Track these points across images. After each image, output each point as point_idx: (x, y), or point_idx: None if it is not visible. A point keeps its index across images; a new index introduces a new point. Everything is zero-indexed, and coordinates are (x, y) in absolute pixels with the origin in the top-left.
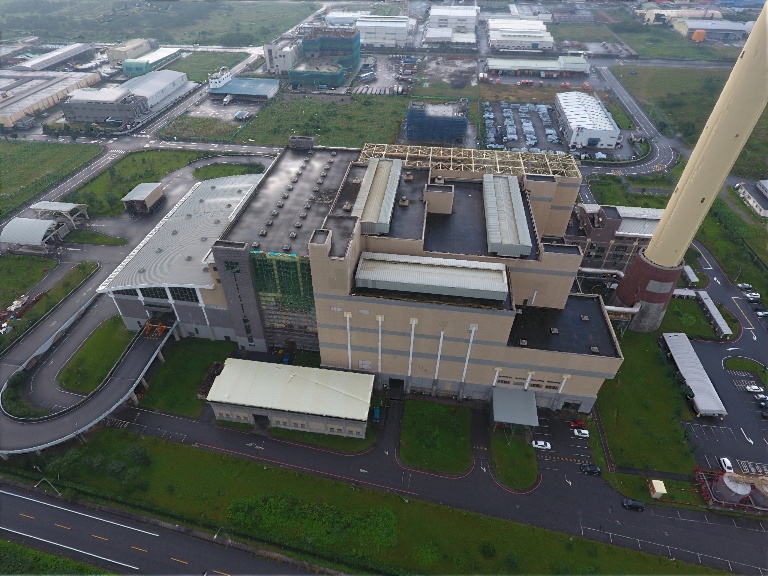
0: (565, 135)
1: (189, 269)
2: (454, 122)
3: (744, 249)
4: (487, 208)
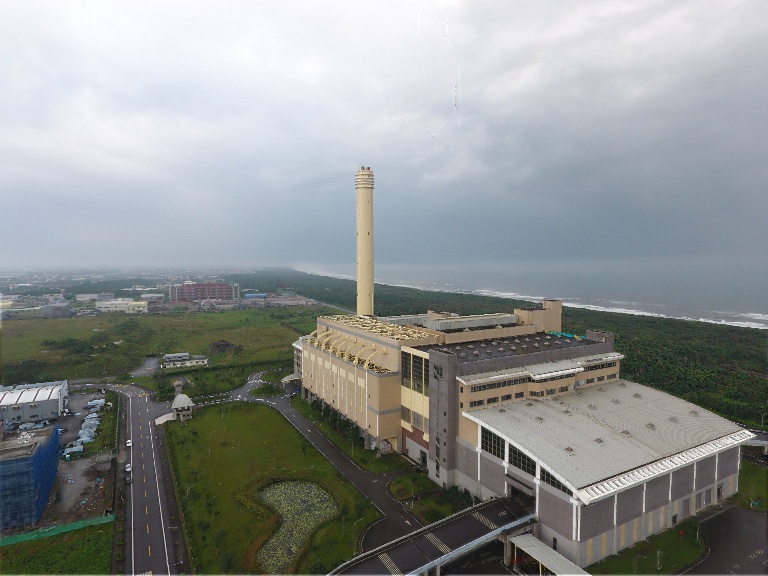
0: (17, 422)
1: (639, 392)
2: (53, 440)
3: (268, 360)
4: (429, 317)
